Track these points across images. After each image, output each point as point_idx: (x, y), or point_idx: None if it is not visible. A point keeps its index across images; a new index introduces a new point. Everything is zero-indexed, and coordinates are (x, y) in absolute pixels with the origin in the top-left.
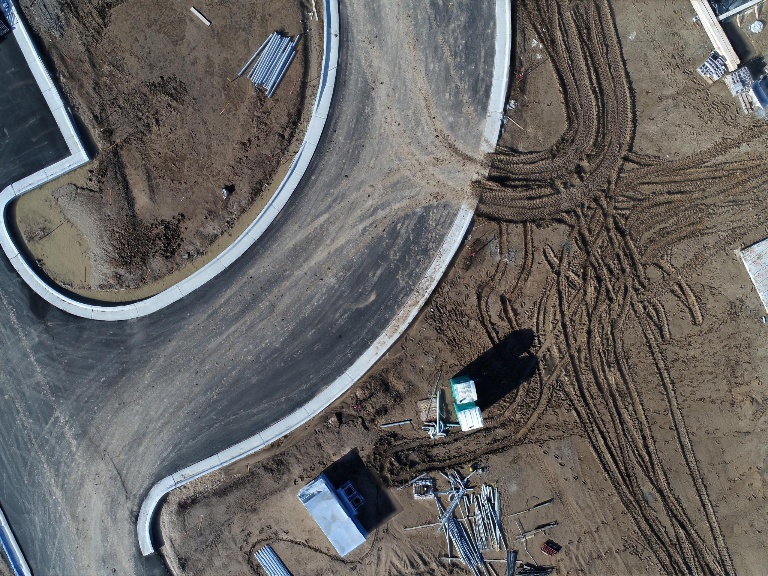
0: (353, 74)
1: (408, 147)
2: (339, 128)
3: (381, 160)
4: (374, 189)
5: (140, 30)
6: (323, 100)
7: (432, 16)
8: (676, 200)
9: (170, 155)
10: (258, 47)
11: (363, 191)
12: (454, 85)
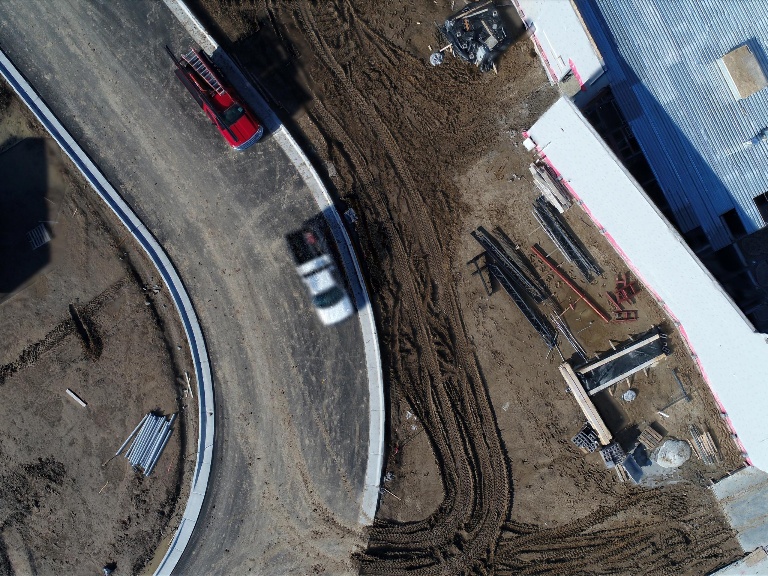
0: (230, 450)
1: (287, 521)
2: (218, 503)
3: (261, 534)
4: (255, 562)
5: (17, 413)
6: (201, 477)
7: (306, 392)
8: (556, 567)
9: (51, 535)
10: (134, 427)
11: (244, 565)
12: (330, 459)
